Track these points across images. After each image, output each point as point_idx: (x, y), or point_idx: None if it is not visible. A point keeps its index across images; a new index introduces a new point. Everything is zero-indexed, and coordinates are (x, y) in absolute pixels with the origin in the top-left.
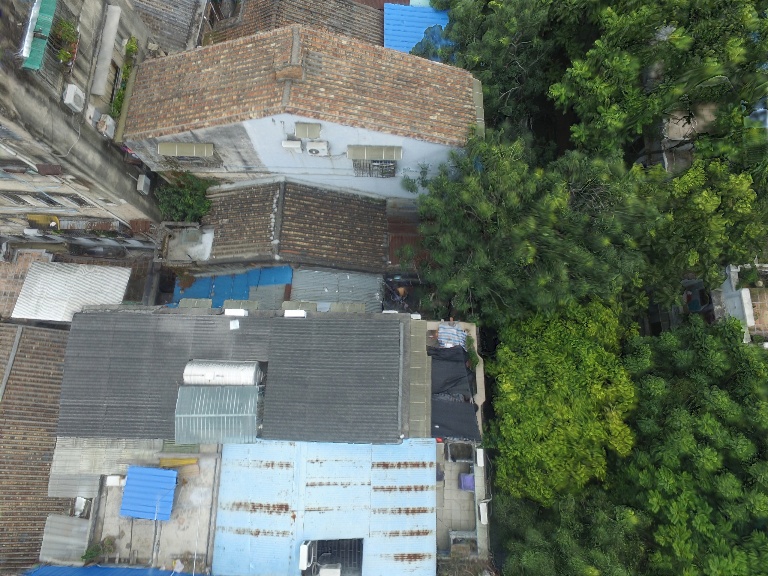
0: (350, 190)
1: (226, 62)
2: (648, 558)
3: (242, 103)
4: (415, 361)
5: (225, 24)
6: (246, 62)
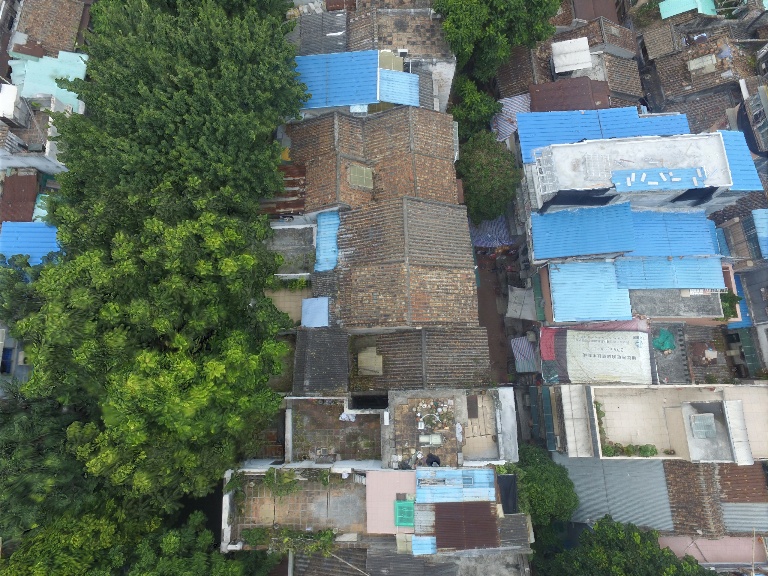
0: None
1: None
2: None
3: None
4: None
5: None
6: None
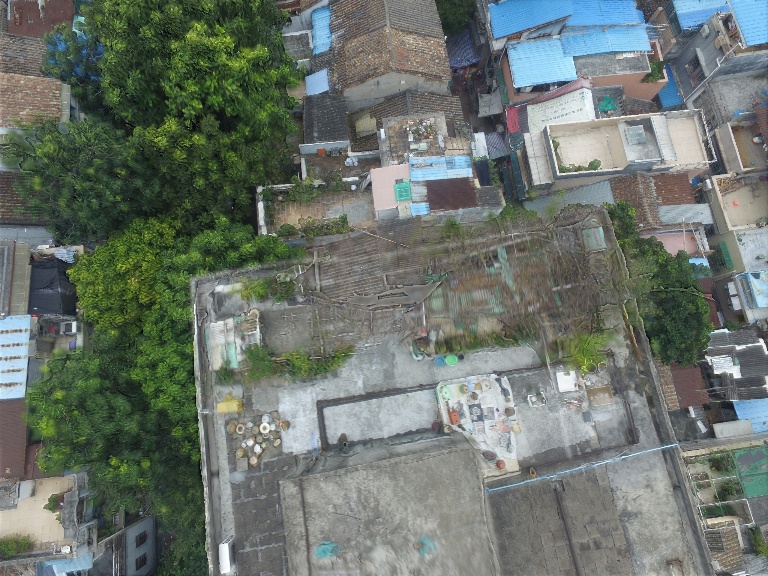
0: (22, 170)
1: None
2: (135, 361)
3: None
4: (18, 269)
5: None
6: None
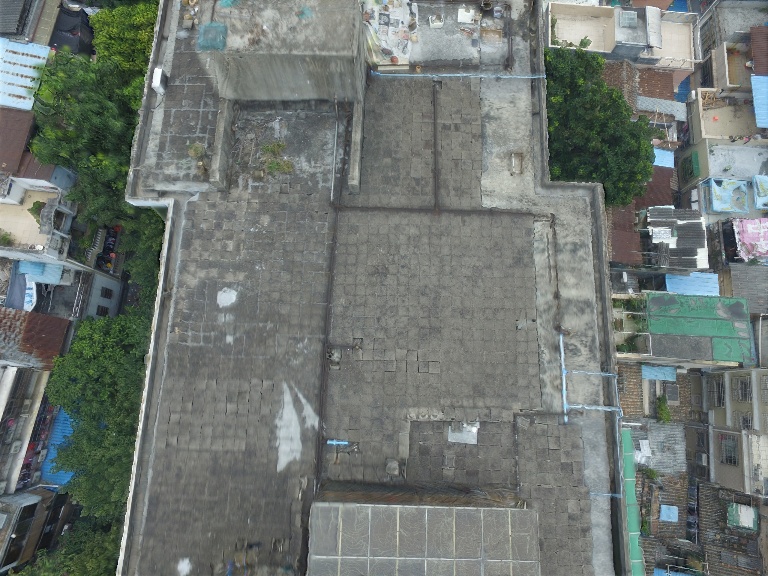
0: None
1: None
2: None
3: None
4: (48, 8)
5: None
6: None
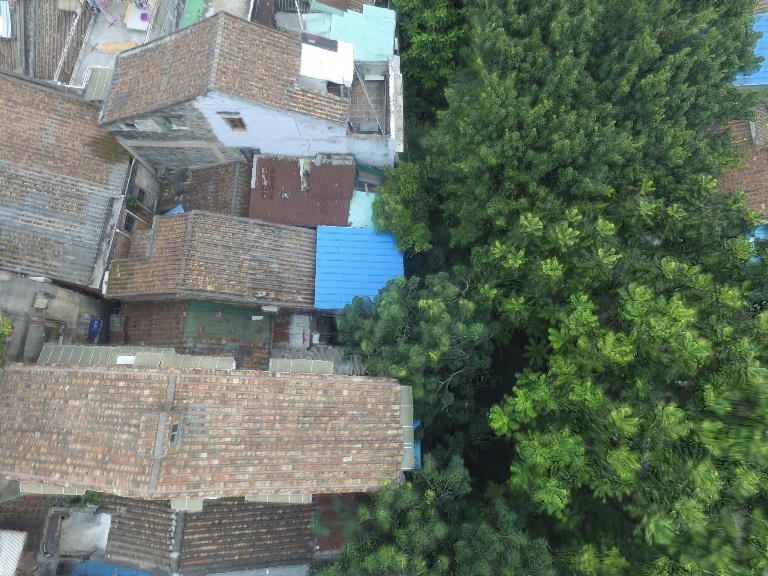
0: None
1: (94, 400)
2: None
3: (106, 470)
4: None
5: (141, 236)
6: (115, 408)
